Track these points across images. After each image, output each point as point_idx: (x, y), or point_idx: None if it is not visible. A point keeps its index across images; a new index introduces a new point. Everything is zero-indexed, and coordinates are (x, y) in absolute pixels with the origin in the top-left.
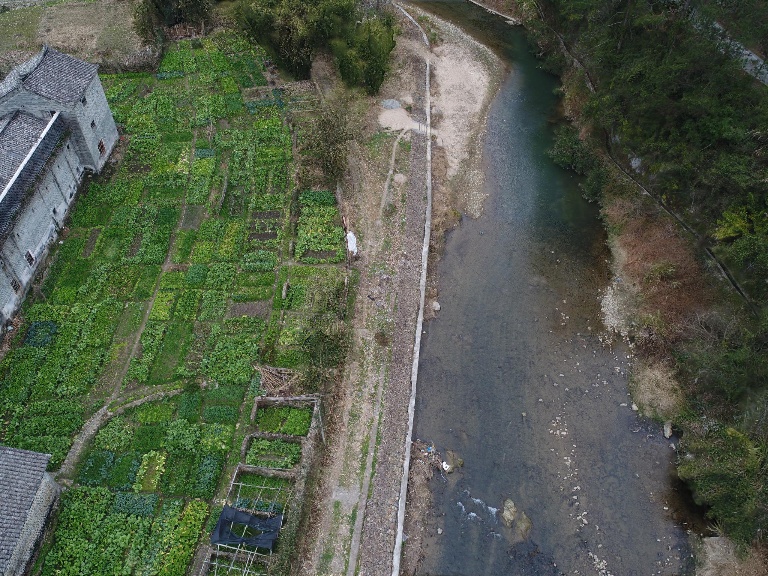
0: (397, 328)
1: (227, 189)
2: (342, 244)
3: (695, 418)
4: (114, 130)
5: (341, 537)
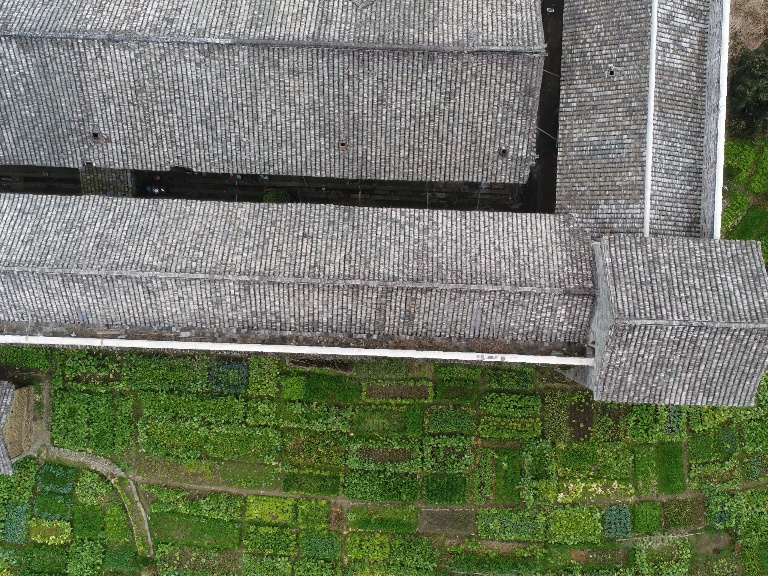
0: None
1: None
2: None
3: None
4: None
5: None
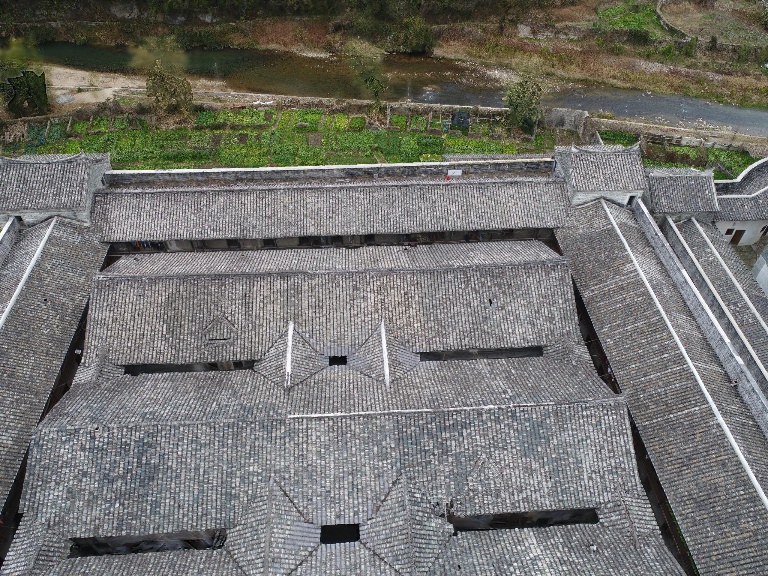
0: None
1: None
2: None
3: None
4: None
5: None
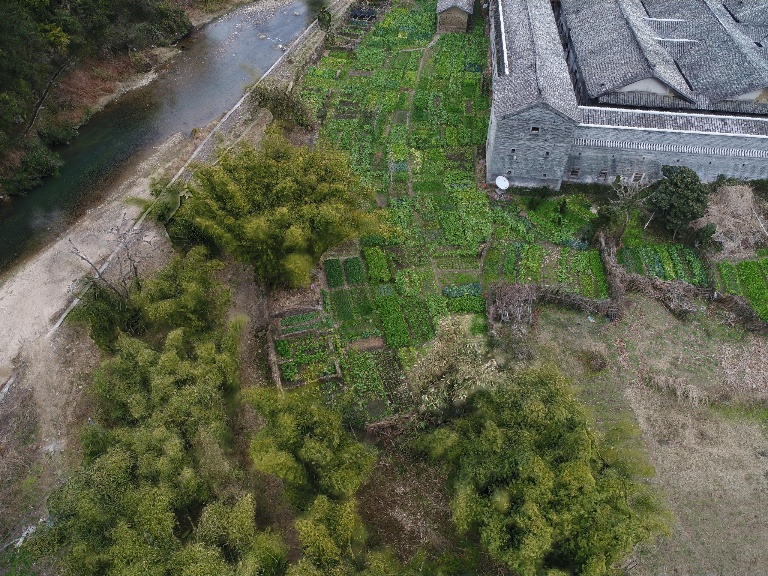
0: None
1: None
2: None
3: (159, 42)
4: None
5: None
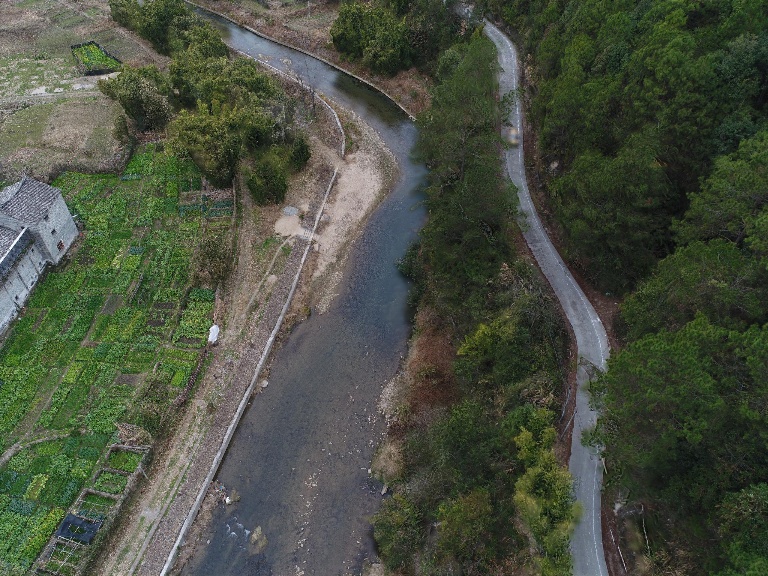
0: (225, 401)
1: (142, 283)
2: (208, 333)
3: (404, 483)
4: (74, 230)
5: (138, 539)
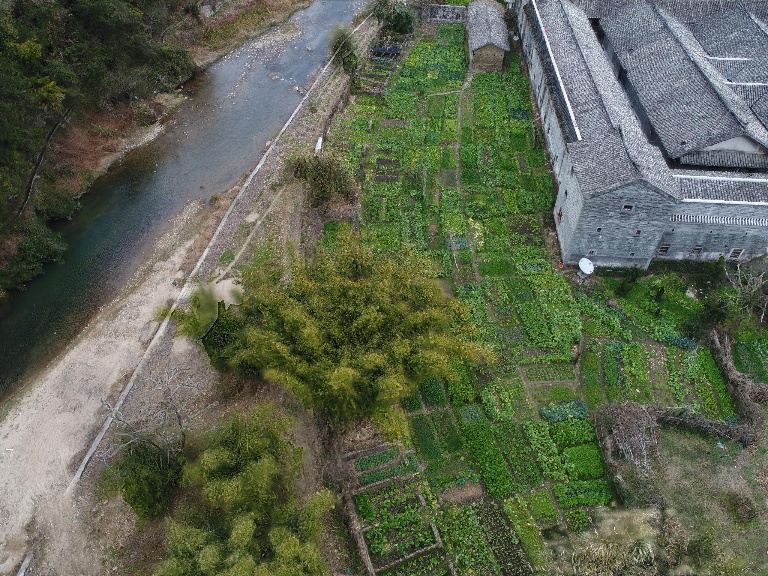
0: None
1: None
2: None
3: (162, 87)
4: None
5: None
